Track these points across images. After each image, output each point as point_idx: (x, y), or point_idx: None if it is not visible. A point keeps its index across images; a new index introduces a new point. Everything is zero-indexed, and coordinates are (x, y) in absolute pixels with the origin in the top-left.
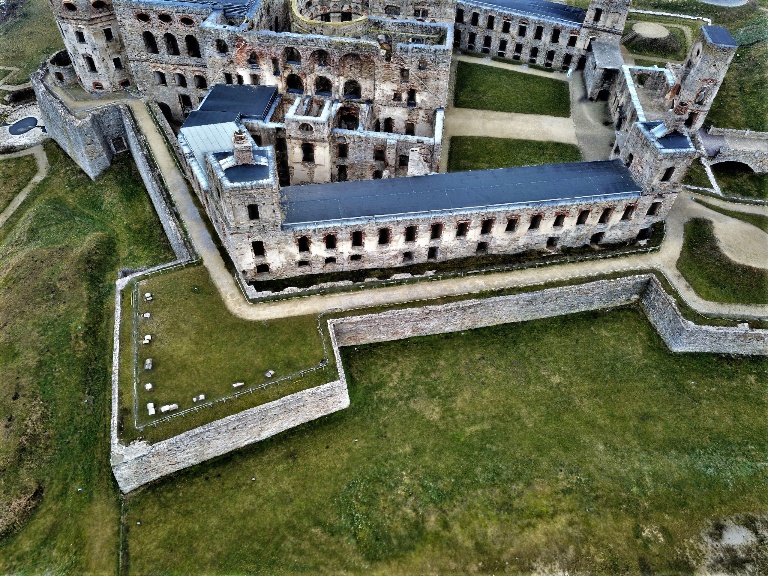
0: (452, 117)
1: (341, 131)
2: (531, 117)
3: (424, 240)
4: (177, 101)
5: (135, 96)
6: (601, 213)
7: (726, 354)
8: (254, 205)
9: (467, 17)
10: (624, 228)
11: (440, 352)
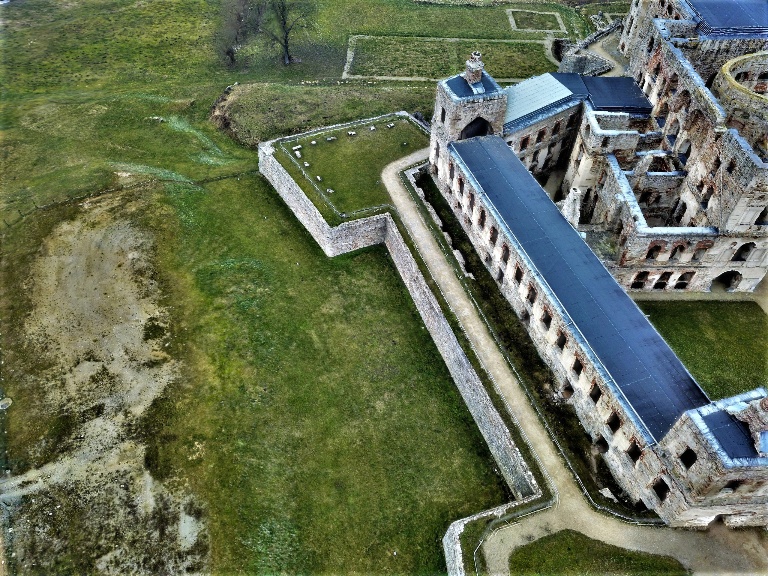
0: None
1: (612, 160)
2: None
3: (498, 254)
4: None
5: None
6: (610, 412)
7: None
8: None
9: None
10: (627, 470)
11: (396, 311)
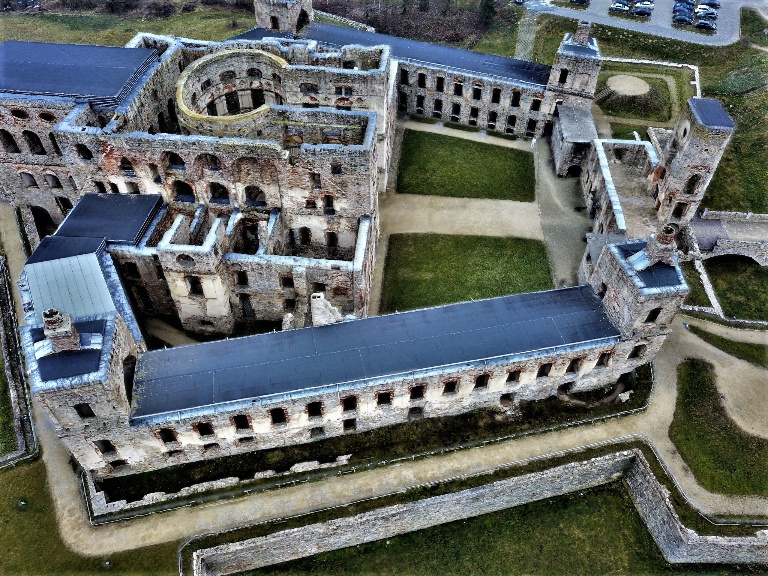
0: (392, 207)
1: (234, 257)
2: (488, 203)
3: (334, 414)
4: (55, 204)
5: (5, 199)
6: (568, 364)
7: (741, 565)
8: (83, 404)
9: (412, 78)
10: (600, 375)
11: None
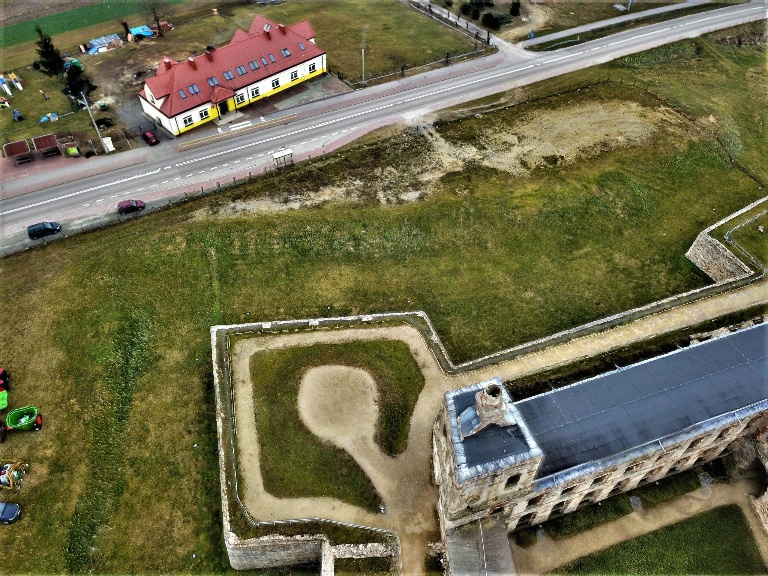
0: None
1: None
2: None
3: None
4: None
5: None
6: None
7: None
8: None
9: None
10: None
11: (637, 304)
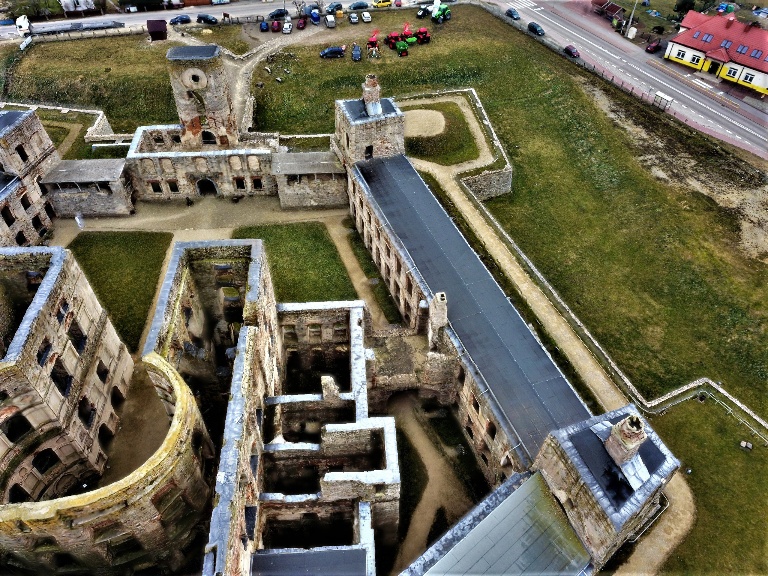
0: None
1: None
2: None
3: None
4: None
5: None
6: None
7: None
8: None
9: None
10: None
11: None
